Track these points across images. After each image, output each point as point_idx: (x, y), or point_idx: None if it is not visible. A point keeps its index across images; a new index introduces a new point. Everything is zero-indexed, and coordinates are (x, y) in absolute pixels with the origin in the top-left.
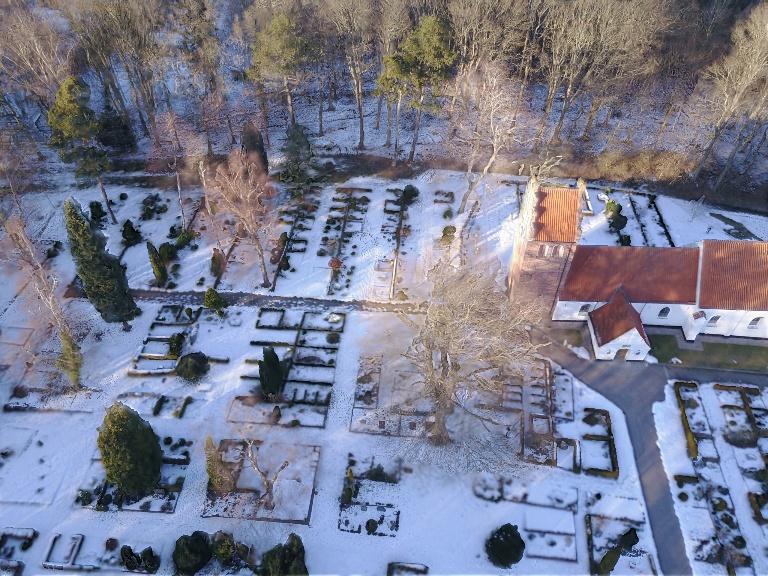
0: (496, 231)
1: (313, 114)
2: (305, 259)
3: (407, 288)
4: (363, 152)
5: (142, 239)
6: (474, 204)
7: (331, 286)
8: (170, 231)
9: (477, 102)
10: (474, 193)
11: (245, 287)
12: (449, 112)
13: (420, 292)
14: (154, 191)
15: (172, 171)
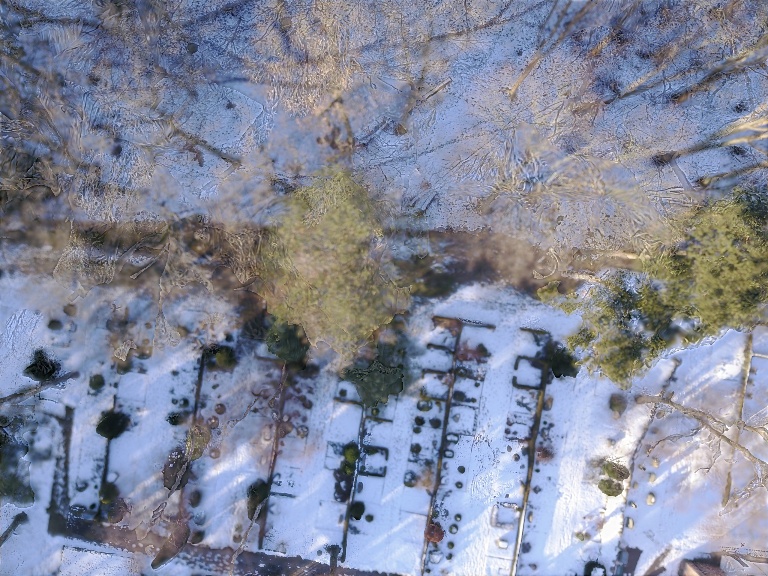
0: (689, 451)
1: (381, 8)
2: (386, 492)
3: (535, 566)
4: (486, 222)
5: (128, 423)
6: (667, 383)
7: (427, 557)
8: (170, 423)
9: (735, 0)
10: (681, 447)
11: (303, 546)
12: (668, 43)
13: (553, 574)
14: (117, 296)
15: (137, 253)
